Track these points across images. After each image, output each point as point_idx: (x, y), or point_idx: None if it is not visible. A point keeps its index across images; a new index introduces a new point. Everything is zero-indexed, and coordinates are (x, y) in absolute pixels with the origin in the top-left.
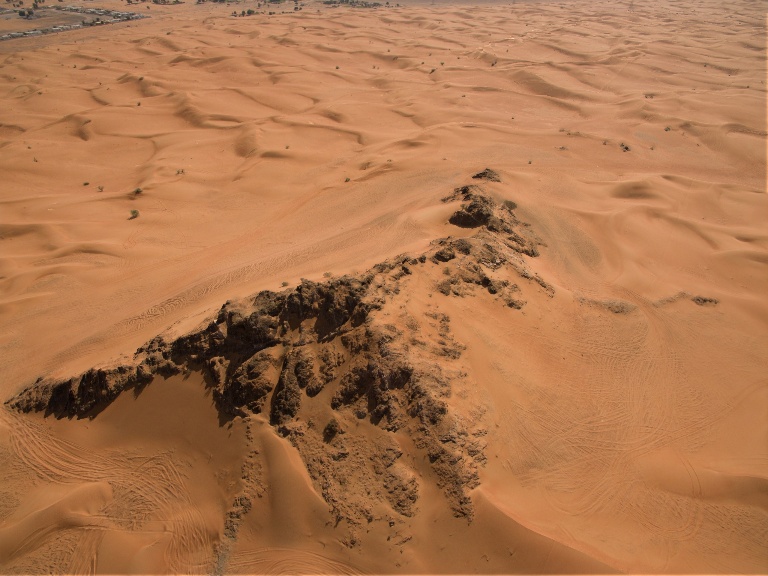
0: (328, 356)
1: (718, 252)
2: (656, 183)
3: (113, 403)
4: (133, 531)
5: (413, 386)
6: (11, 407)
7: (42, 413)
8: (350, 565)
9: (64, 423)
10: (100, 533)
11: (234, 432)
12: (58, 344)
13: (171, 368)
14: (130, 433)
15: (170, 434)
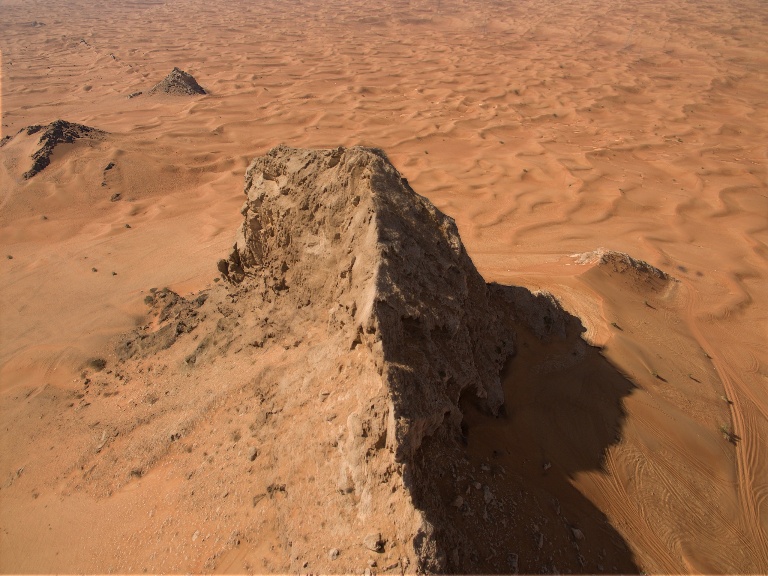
0: (72, 129)
1: (84, 123)
2: (41, 123)
3: (50, 159)
4: (84, 154)
5: (87, 127)
6: (29, 178)
7: (38, 172)
8: (109, 141)
9: (46, 168)
10: (81, 157)
11: (76, 142)
12: (7, 180)
13: (52, 147)
14: (61, 157)
15: (68, 151)
